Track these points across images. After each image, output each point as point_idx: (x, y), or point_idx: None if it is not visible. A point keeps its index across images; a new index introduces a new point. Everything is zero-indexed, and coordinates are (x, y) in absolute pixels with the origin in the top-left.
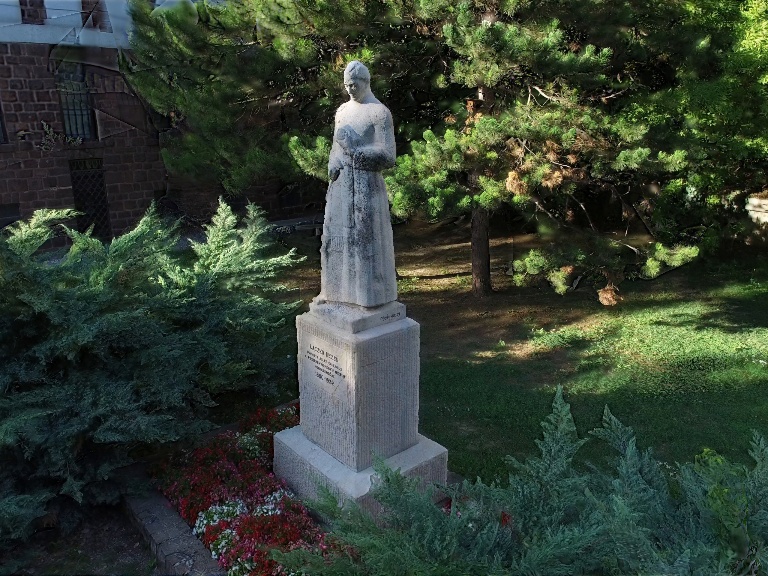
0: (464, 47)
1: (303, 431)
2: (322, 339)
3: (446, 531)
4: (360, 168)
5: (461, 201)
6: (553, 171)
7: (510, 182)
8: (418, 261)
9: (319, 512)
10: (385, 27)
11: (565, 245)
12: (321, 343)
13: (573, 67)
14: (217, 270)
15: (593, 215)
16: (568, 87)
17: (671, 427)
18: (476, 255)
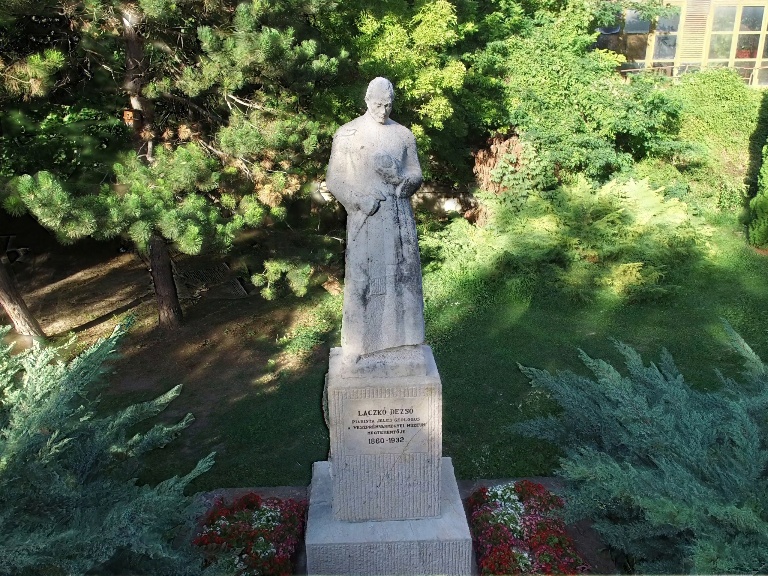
0: (222, 53)
1: (341, 518)
2: (383, 397)
3: (682, 483)
4: (404, 196)
5: (233, 224)
6: (286, 179)
7: (268, 195)
8: (36, 315)
9: (668, 520)
10: (26, 19)
11: (289, 249)
12: (381, 402)
13: (312, 75)
14: (40, 390)
15: (289, 216)
16: (287, 94)
17: (476, 370)
18: (164, 284)
